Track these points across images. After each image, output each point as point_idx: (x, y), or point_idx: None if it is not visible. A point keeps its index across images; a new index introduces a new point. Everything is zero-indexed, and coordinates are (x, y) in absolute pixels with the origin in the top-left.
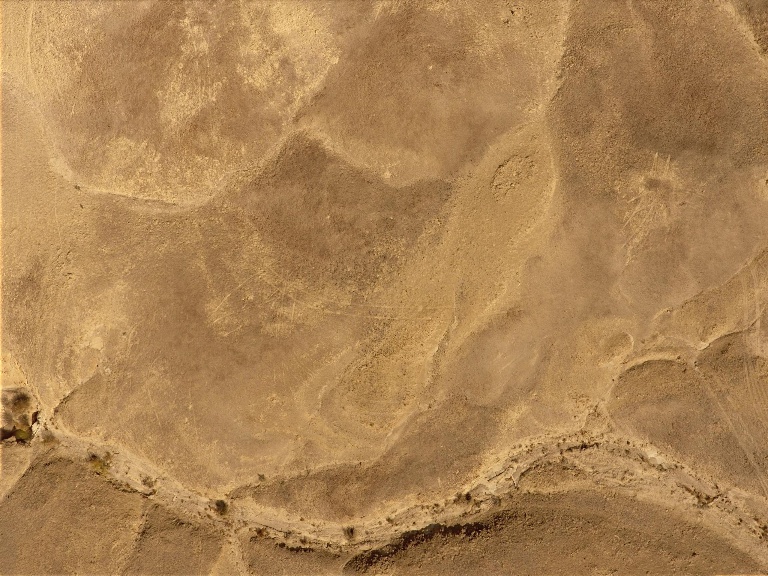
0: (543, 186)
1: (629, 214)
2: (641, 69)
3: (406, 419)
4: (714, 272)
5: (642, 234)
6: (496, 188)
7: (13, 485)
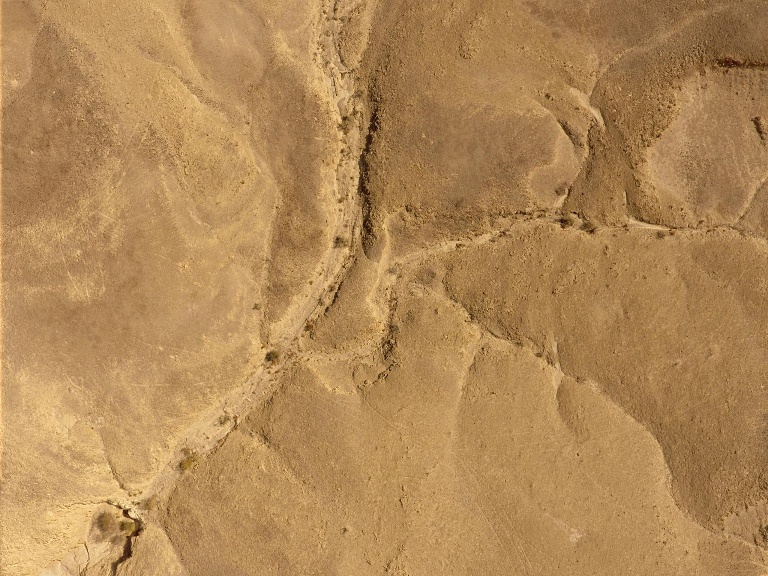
0: None
1: None
2: None
3: (251, 150)
4: None
5: None
6: None
7: (174, 552)
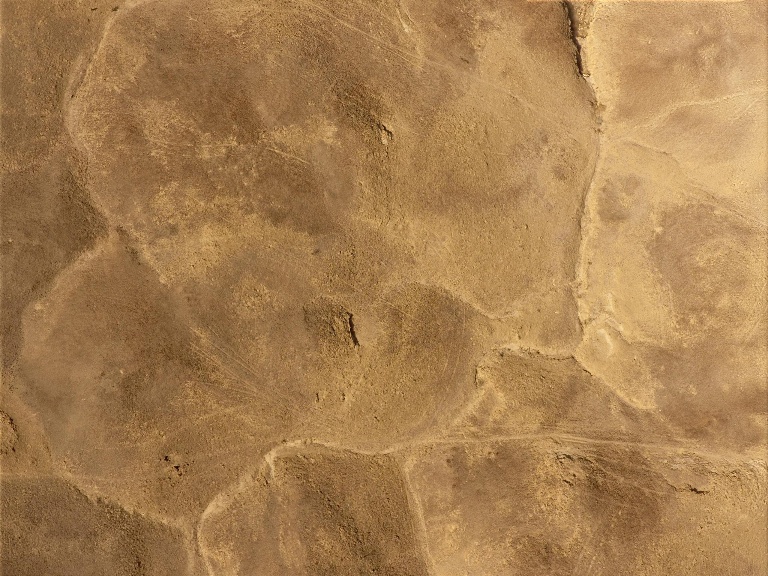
0: None
1: None
2: None
3: None
4: None
5: None
6: None
7: None
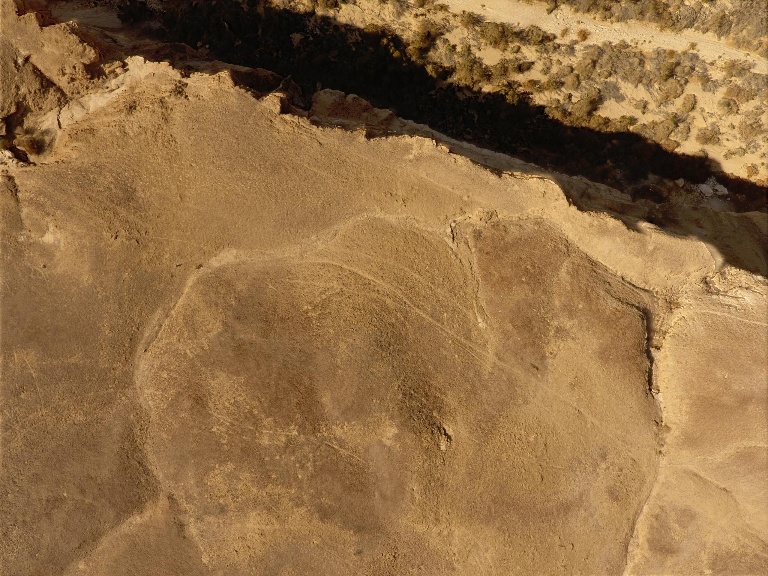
0: None
1: None
2: None
3: None
4: None
5: None
6: None
7: None
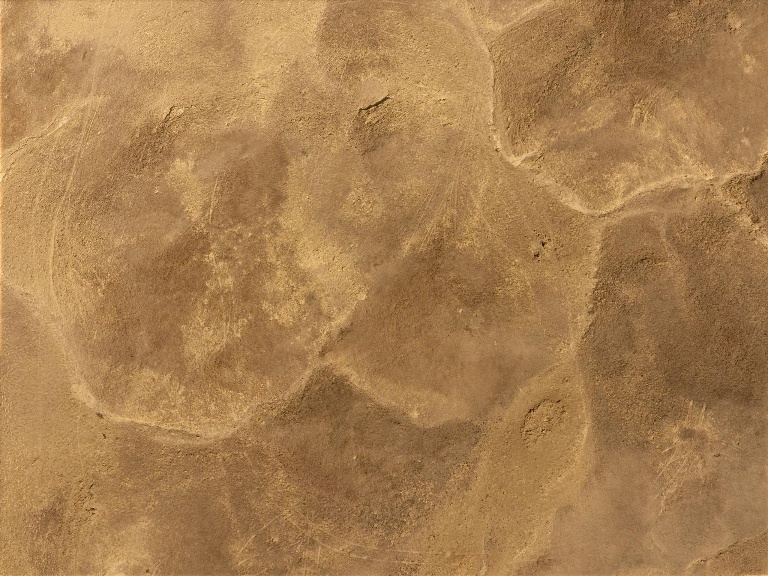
0: (575, 433)
1: (663, 465)
2: (675, 308)
3: None
4: (750, 523)
5: (676, 485)
6: (526, 434)
7: None
